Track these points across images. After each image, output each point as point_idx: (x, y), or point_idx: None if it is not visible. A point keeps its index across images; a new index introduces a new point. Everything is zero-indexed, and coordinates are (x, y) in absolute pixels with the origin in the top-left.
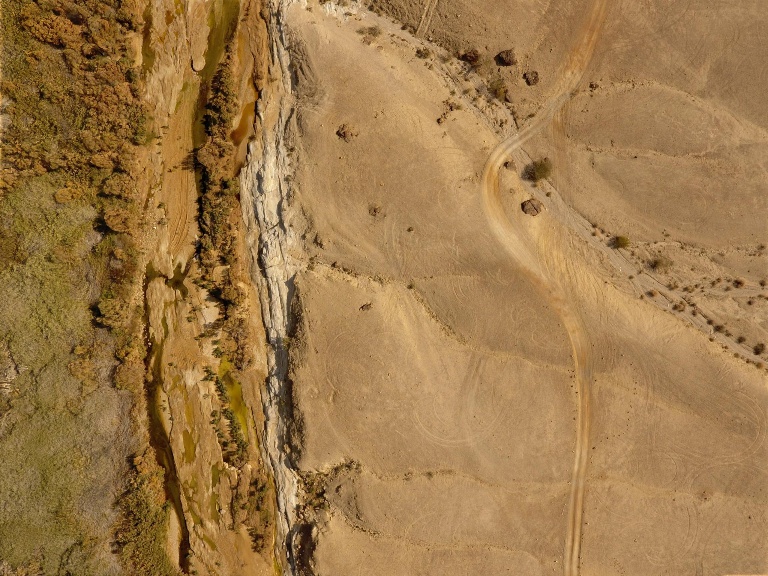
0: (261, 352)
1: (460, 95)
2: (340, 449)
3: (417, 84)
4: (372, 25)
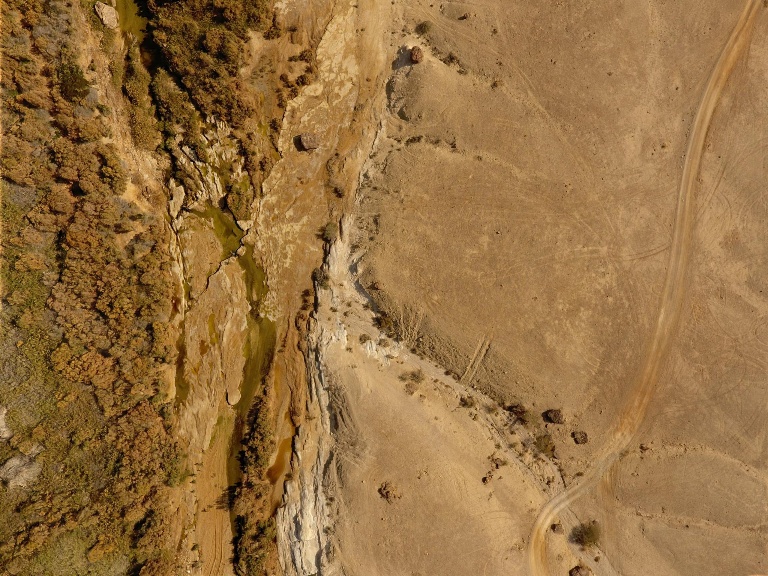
0: None
1: (506, 448)
2: None
3: (461, 437)
4: (414, 369)
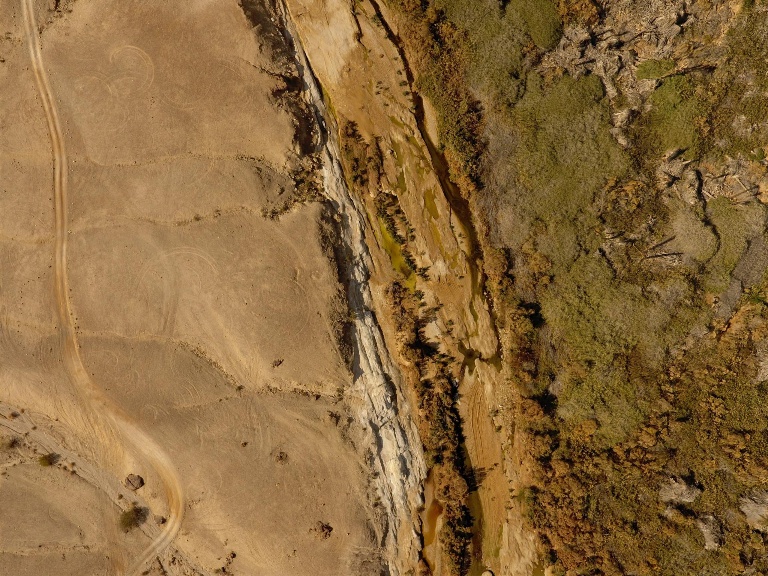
0: (378, 302)
1: None
2: (284, 228)
3: None
4: None
